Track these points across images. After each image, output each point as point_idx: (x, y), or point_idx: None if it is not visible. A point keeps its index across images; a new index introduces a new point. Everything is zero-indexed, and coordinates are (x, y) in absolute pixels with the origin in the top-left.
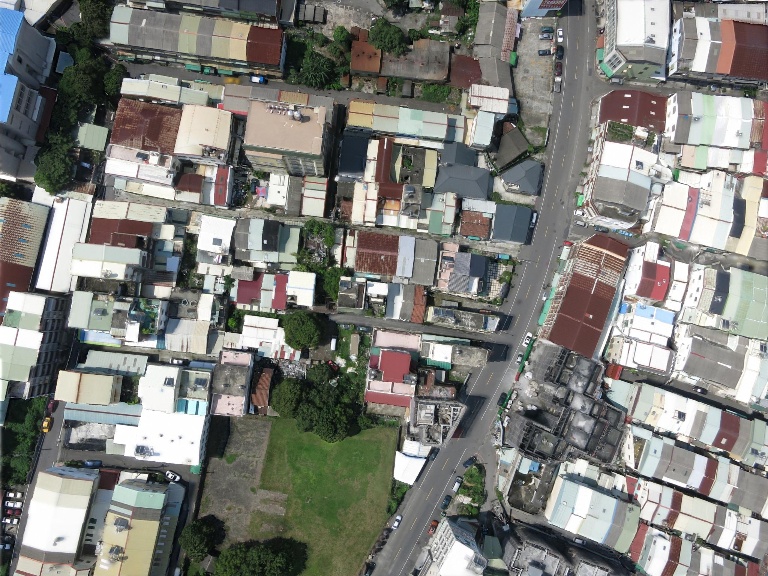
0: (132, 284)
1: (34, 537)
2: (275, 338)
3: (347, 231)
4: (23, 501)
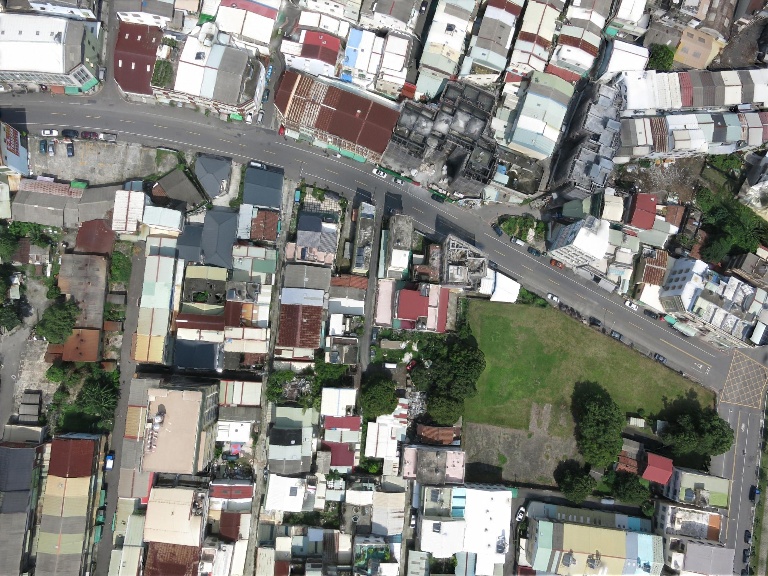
0: (339, 575)
1: None
2: (387, 425)
3: (276, 357)
4: None
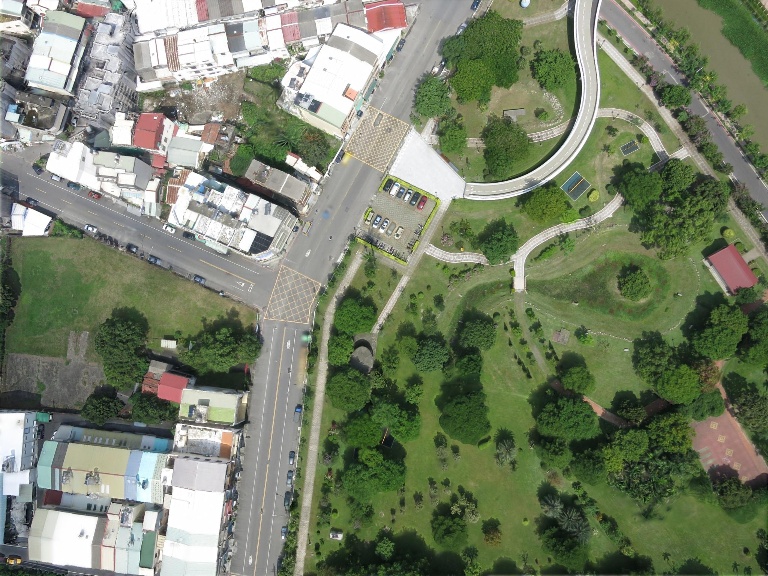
0: None
1: (81, 557)
2: None
3: None
4: (83, 575)
